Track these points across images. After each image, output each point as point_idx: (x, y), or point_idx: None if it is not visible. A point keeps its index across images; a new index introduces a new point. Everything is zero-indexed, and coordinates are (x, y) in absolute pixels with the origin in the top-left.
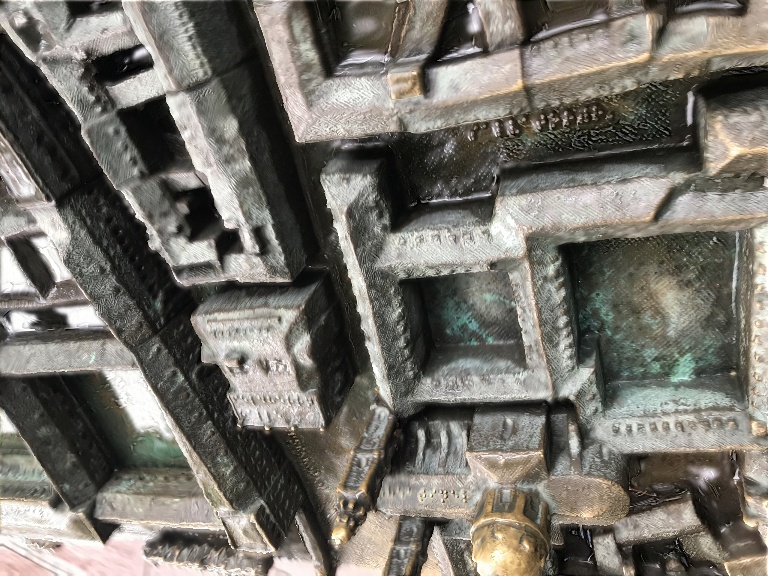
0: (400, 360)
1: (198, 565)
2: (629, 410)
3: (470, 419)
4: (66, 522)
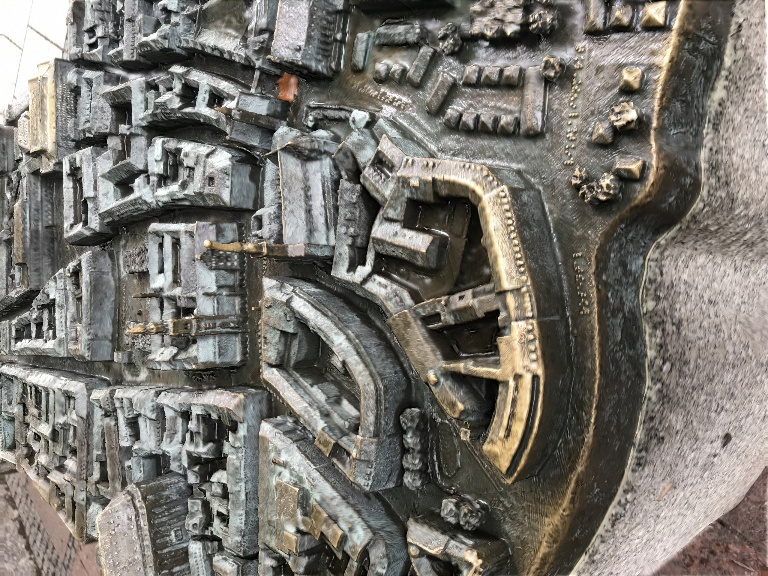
0: (5, 375)
1: None
2: (6, 425)
3: (1, 387)
4: None
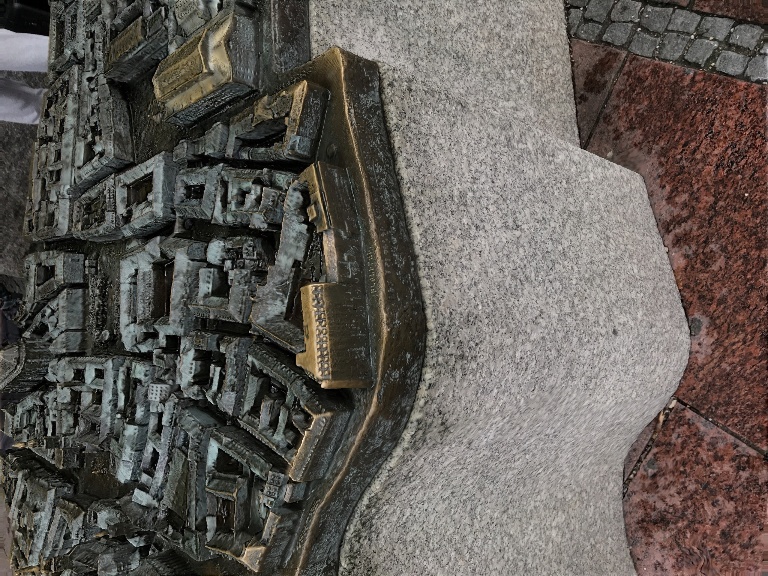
0: None
1: None
2: None
3: None
4: None
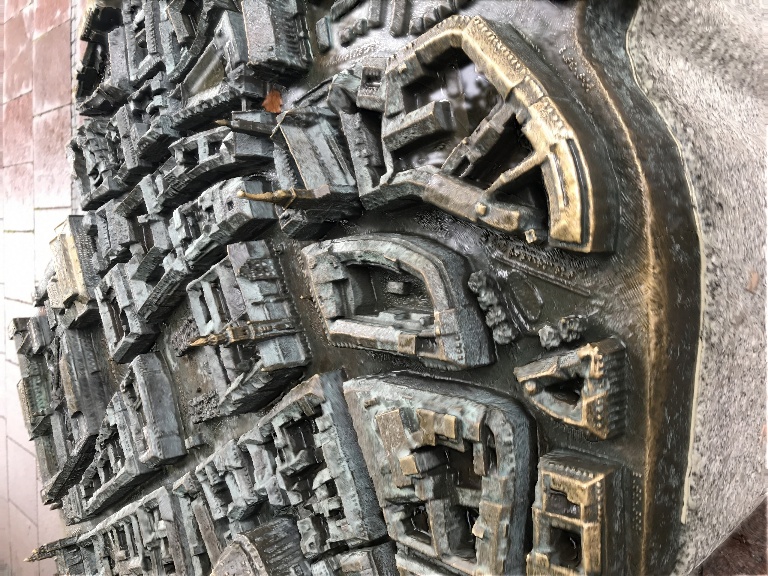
0: None
1: (39, 467)
2: None
3: None
4: (29, 430)
